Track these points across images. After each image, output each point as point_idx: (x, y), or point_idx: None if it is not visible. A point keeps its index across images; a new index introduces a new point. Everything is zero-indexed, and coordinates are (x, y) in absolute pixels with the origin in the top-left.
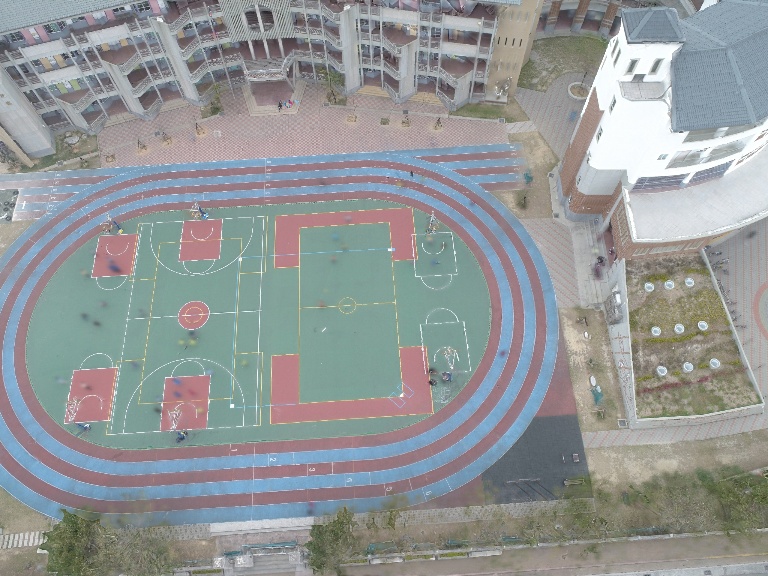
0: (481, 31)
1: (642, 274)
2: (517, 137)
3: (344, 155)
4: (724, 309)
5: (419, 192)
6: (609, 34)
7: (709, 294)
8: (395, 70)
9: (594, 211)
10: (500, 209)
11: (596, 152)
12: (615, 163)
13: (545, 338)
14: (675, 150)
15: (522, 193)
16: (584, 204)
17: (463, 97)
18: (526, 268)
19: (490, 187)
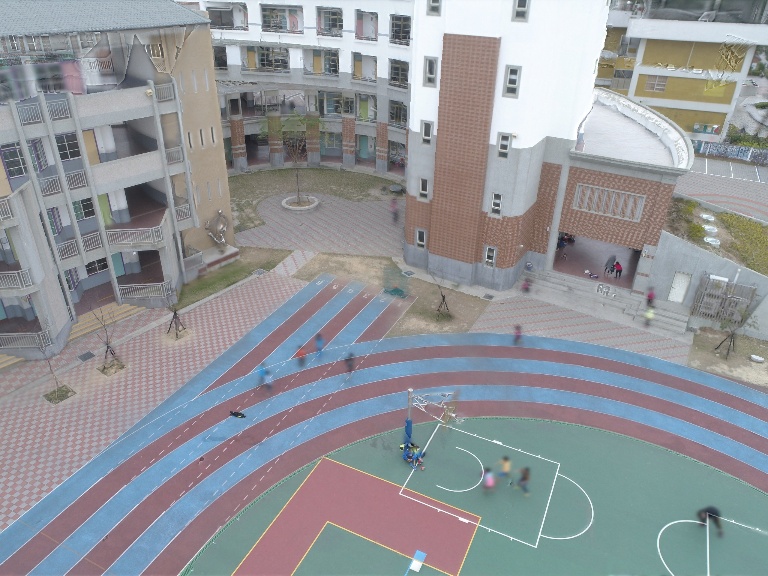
0: (156, 111)
1: (686, 237)
2: (308, 272)
3: (28, 516)
4: (751, 219)
5: (295, 425)
6: (247, 165)
7: (727, 216)
8: (12, 272)
9: (524, 249)
10: (432, 341)
11: (522, 115)
12: (539, 127)
13: (762, 407)
14: (600, 48)
15: (418, 308)
16: (519, 239)
17: (174, 271)
18: (584, 365)
19: (375, 333)
